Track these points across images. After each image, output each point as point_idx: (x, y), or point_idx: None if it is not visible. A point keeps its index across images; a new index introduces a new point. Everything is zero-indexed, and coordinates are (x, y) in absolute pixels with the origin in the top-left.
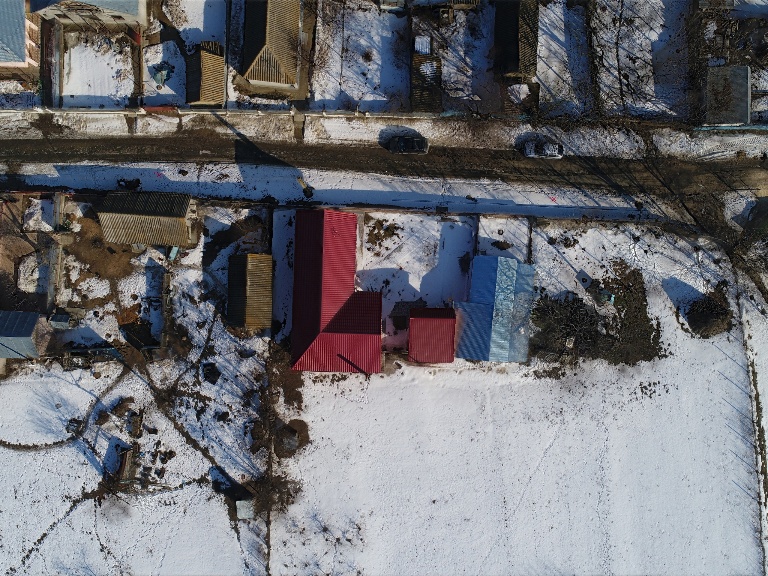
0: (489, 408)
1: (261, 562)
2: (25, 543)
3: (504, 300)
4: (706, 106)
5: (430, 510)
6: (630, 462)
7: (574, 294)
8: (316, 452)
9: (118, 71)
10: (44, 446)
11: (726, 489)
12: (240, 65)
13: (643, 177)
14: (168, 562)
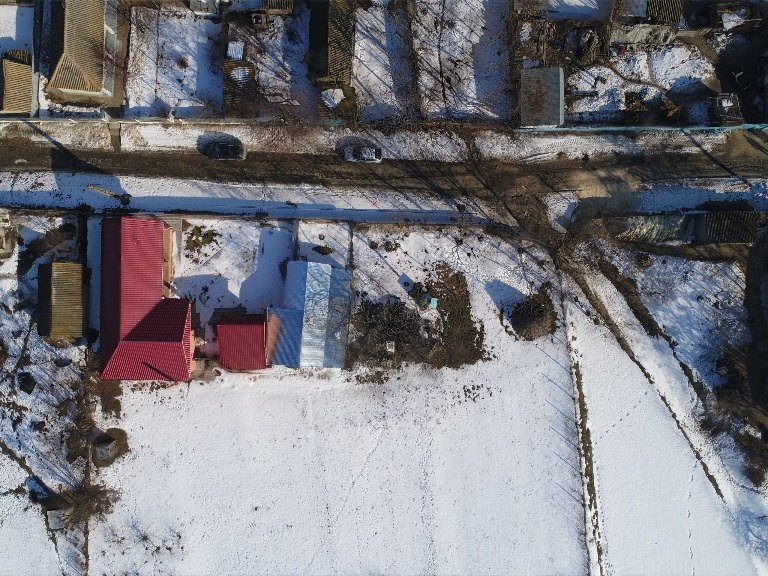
0: (311, 414)
1: (79, 572)
2: None
3: (316, 305)
4: (520, 108)
5: (252, 517)
6: (454, 466)
7: (396, 298)
8: (135, 460)
9: None
10: None
11: (550, 492)
12: None
13: (465, 180)
14: None
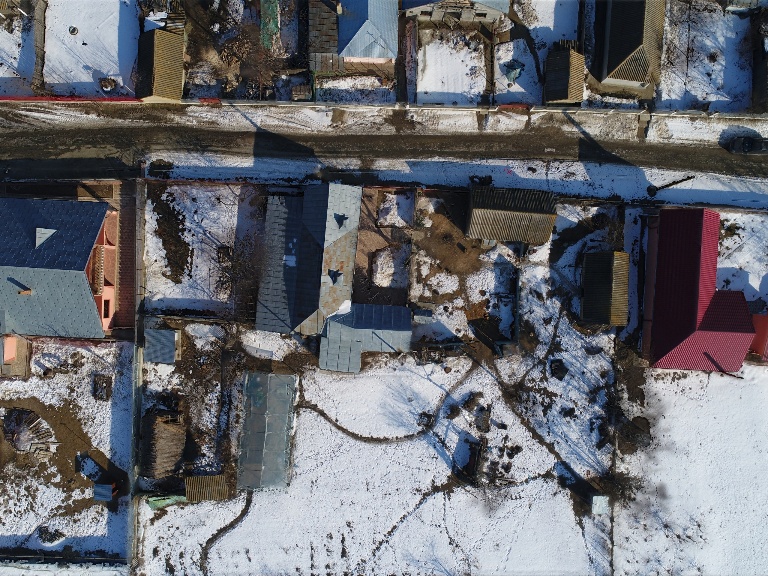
0: None
1: (605, 557)
2: (376, 535)
3: None
4: None
5: (767, 508)
6: None
7: None
8: (657, 449)
9: (473, 68)
10: (395, 439)
11: None
12: (591, 64)
13: None
14: (514, 556)
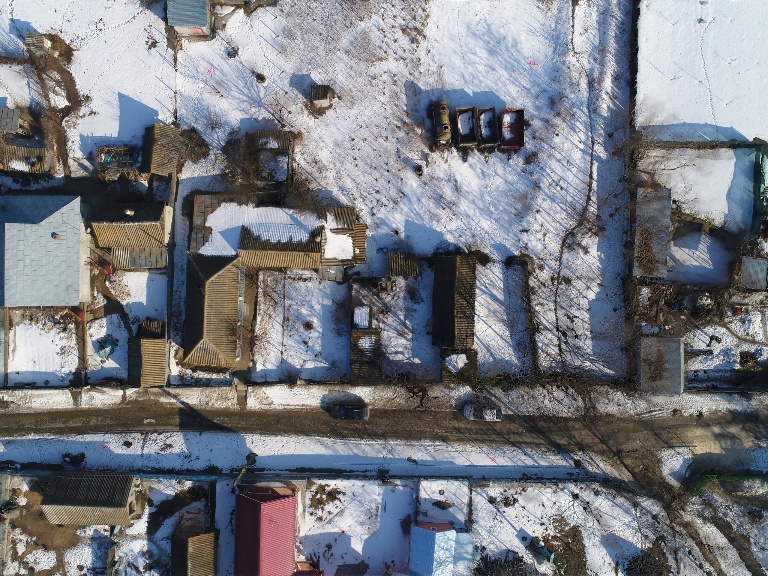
0: None
1: None
2: None
3: (442, 573)
4: (640, 375)
5: None
6: None
7: (514, 552)
8: None
9: (62, 348)
10: None
11: None
12: (182, 339)
13: (581, 435)
14: None
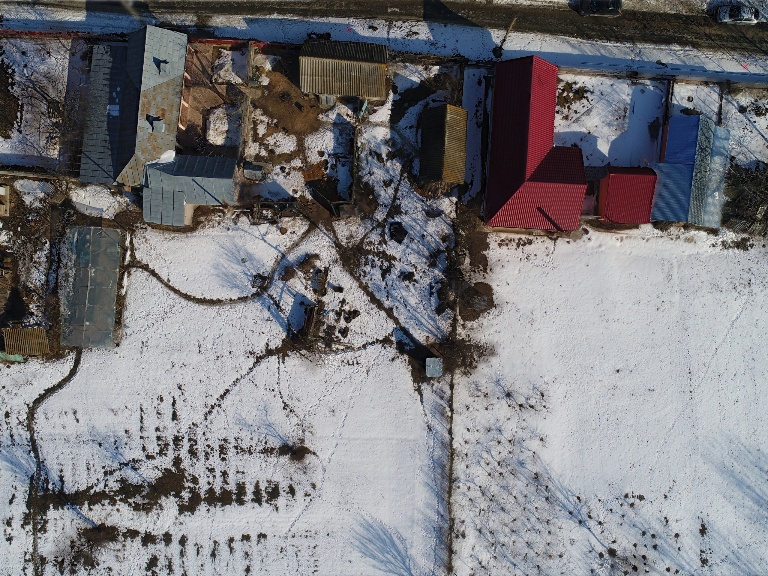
0: (676, 277)
1: (444, 425)
2: (208, 398)
3: (702, 161)
4: None
5: (614, 379)
6: None
7: (764, 164)
8: (500, 316)
9: None
10: (228, 301)
11: None
12: None
13: None
14: (350, 422)
